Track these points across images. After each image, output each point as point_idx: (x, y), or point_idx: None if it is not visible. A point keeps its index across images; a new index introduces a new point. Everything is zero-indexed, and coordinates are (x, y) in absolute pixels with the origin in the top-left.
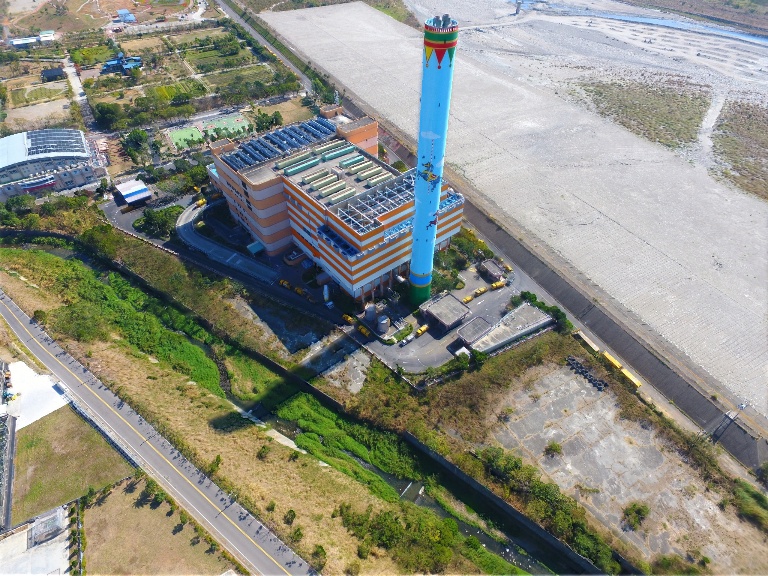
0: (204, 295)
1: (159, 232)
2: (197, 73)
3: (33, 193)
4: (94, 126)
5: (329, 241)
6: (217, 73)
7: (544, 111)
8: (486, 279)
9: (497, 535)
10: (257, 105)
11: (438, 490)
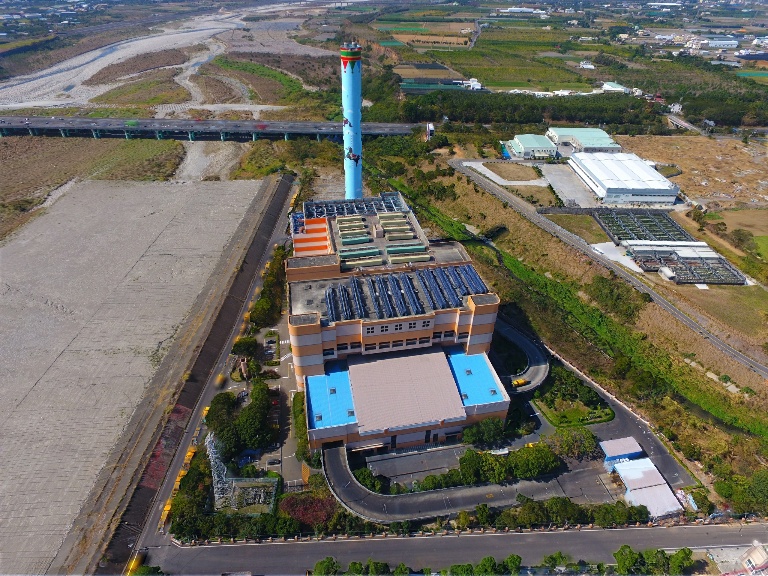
0: None
1: None
2: None
3: None
4: None
5: None
6: None
7: None
8: None
9: None
10: None
11: None
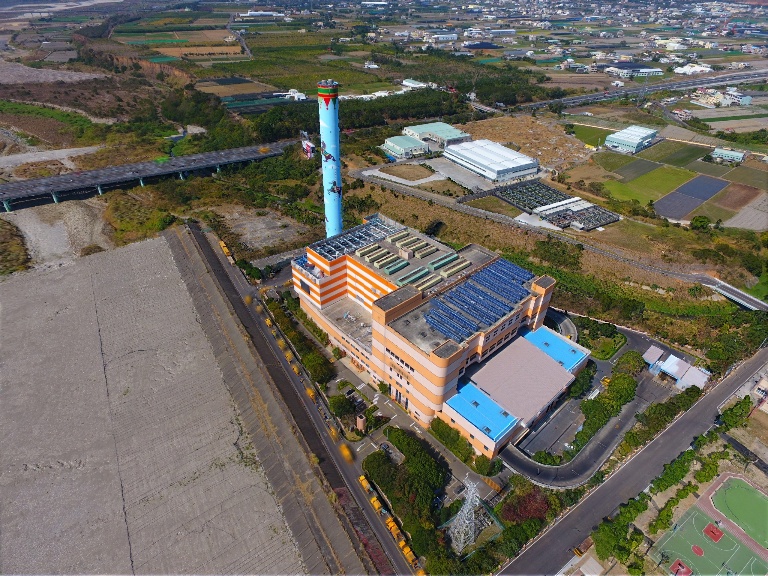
0: None
1: None
2: None
3: None
4: None
5: None
6: None
7: None
8: None
9: None
10: None
11: None
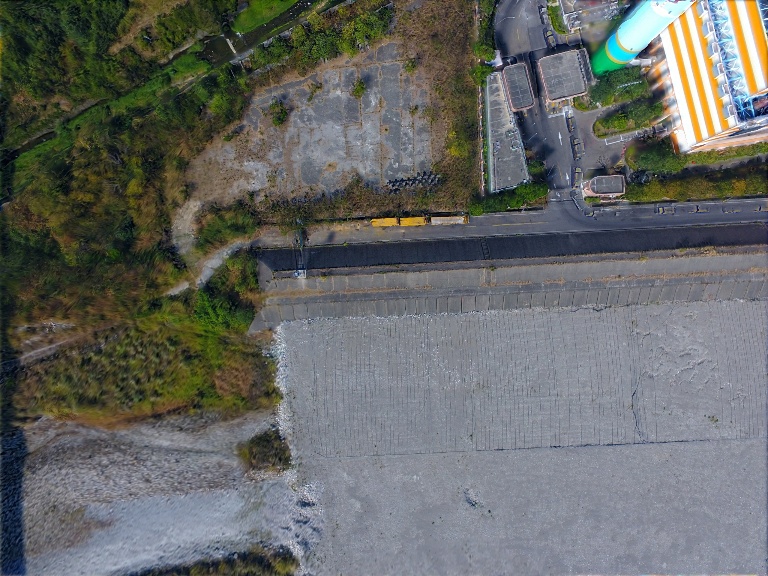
0: None
1: None
2: None
3: None
4: None
5: None
6: None
7: None
8: (595, 172)
9: (322, 2)
10: None
11: None
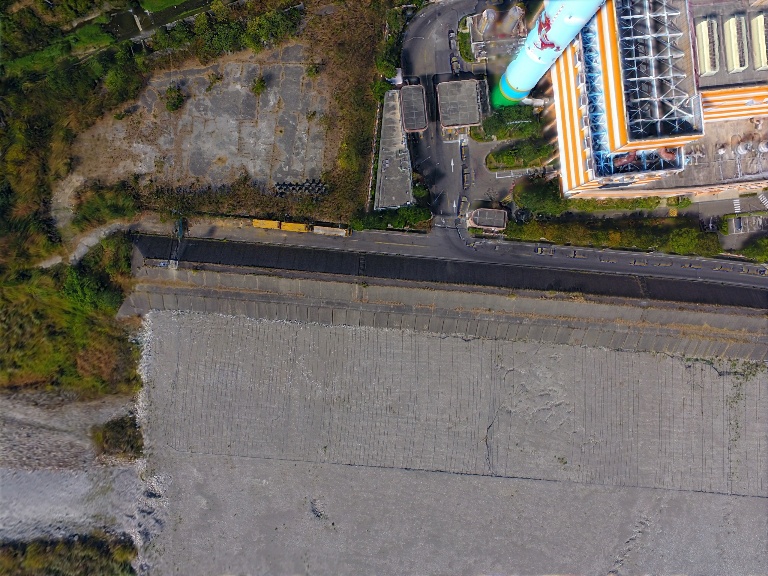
0: None
1: None
2: None
3: None
4: None
5: None
6: None
7: None
8: (482, 204)
9: None
10: None
11: None
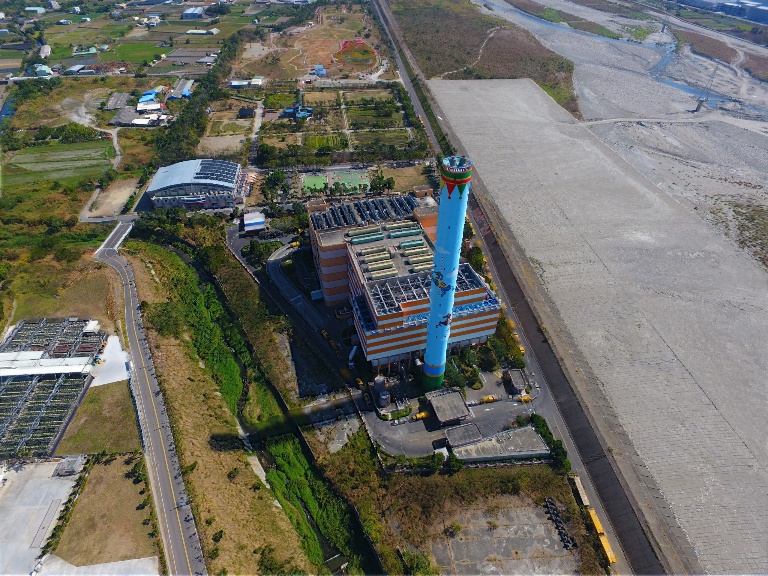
0: (261, 324)
1: (256, 260)
2: (349, 129)
3: (189, 207)
4: (254, 161)
5: (357, 311)
6: (365, 131)
7: (668, 226)
8: (507, 388)
9: None
10: (384, 166)
11: (358, 572)
